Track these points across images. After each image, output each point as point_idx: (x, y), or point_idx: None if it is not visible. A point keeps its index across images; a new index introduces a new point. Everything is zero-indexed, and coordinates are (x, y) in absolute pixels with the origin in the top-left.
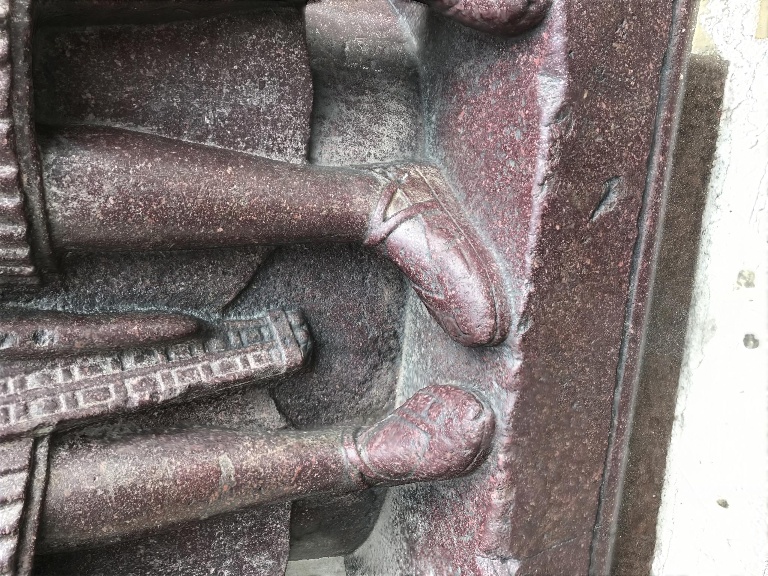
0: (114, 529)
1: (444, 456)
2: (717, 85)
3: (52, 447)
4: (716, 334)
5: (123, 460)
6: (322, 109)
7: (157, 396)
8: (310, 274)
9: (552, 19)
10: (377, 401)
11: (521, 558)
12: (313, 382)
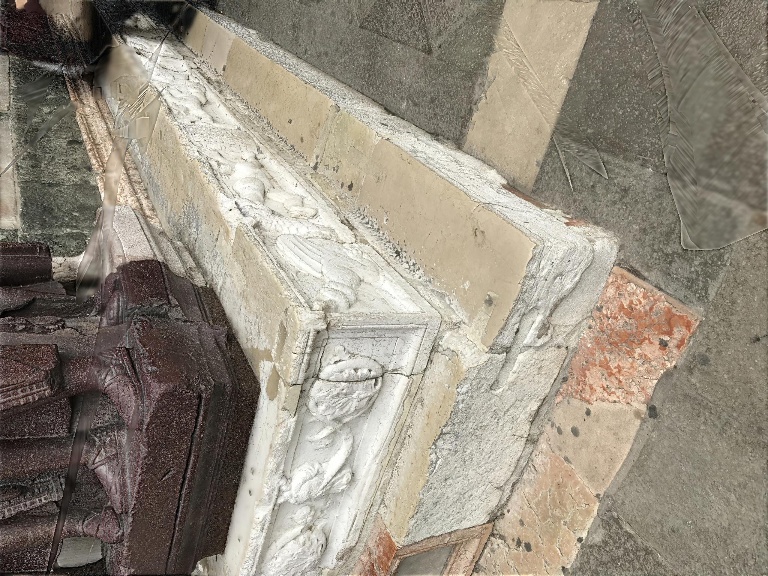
0: None
1: None
2: (255, 397)
3: None
4: None
5: None
6: (79, 407)
7: (5, 517)
8: None
9: None
10: (101, 498)
11: (135, 568)
12: None
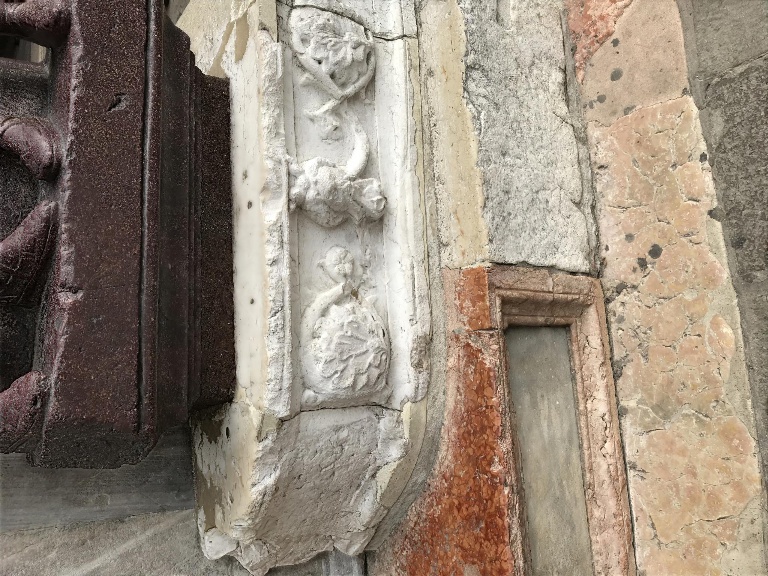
0: None
1: (31, 231)
2: (225, 89)
3: None
4: (240, 212)
5: None
6: None
7: None
8: None
9: (73, 20)
10: None
11: (84, 289)
12: None
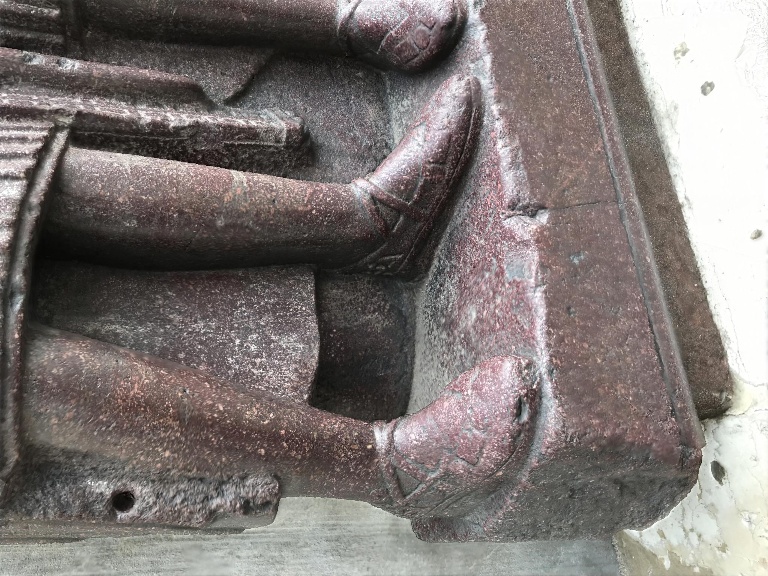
0: (130, 203)
1: (442, 124)
2: None
3: (71, 141)
4: (680, 110)
5: (138, 156)
6: None
7: (168, 123)
8: (299, 92)
9: None
10: None
11: (547, 207)
12: (317, 177)
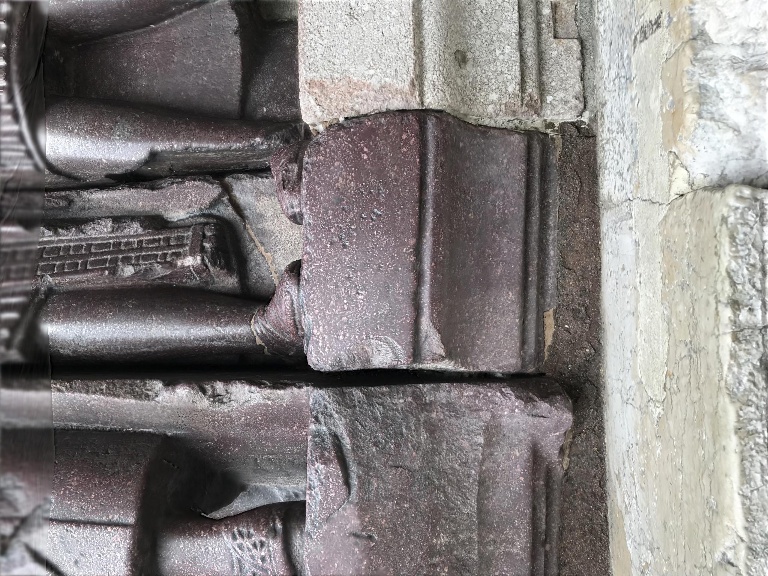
0: None
1: None
2: None
3: None
4: None
5: None
6: None
7: None
8: None
9: None
10: None
11: None
12: None
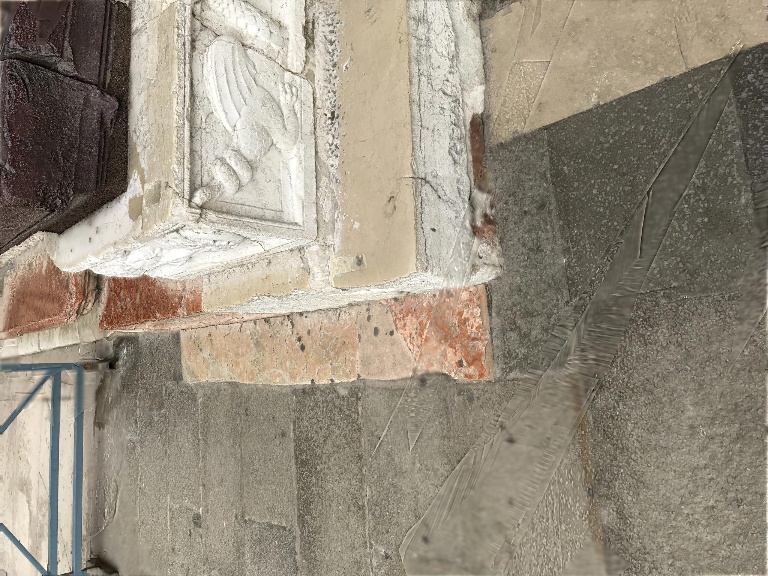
0: None
1: None
2: (119, 192)
3: None
4: (90, 227)
5: None
6: None
7: None
8: None
9: None
10: None
11: None
12: None
